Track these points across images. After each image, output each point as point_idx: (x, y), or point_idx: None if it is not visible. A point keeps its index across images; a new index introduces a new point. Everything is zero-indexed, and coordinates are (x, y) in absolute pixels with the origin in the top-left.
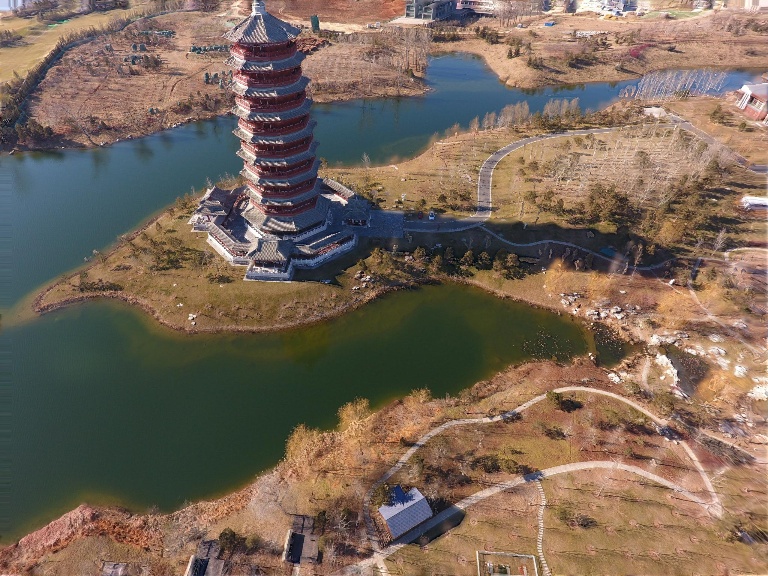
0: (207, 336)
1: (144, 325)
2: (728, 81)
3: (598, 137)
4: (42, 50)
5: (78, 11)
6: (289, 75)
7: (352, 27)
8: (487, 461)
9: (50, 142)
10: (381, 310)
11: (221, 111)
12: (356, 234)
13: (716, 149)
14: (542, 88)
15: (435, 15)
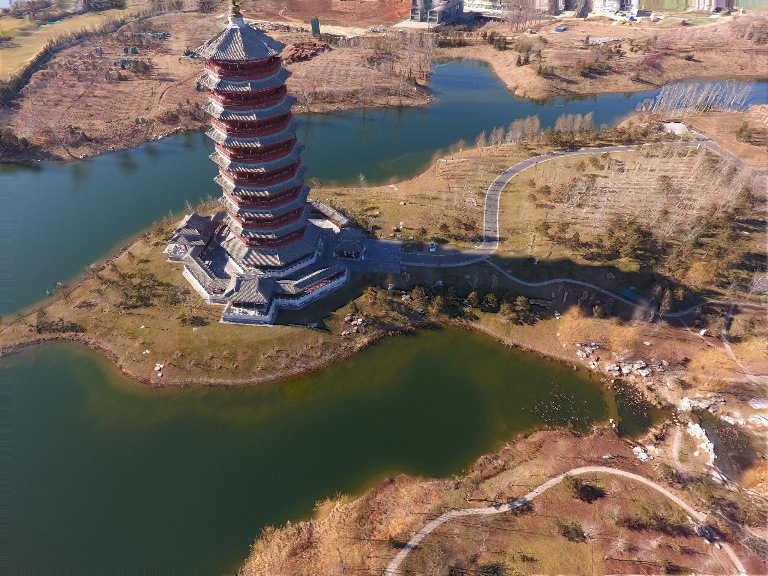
0: (174, 390)
1: (105, 375)
2: (753, 95)
3: (614, 156)
4: (30, 52)
5: (73, 11)
6: (271, 95)
7: (354, 31)
8: (492, 571)
9: (26, 154)
10: (373, 360)
11: None
12: (348, 268)
13: (747, 175)
14: (553, 98)
15: (441, 19)
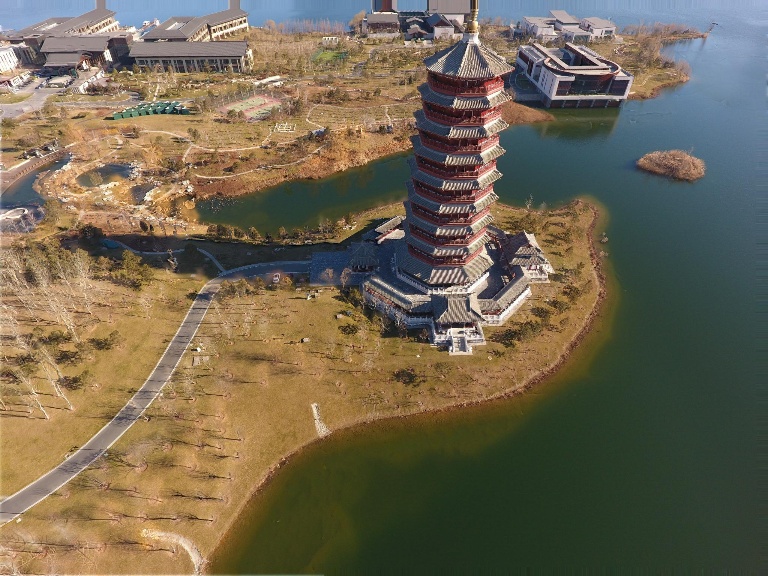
0: None
1: None
2: None
3: None
4: None
5: None
6: None
7: None
8: (282, 150)
9: None
10: (333, 219)
11: None
12: None
13: None
14: None
15: None
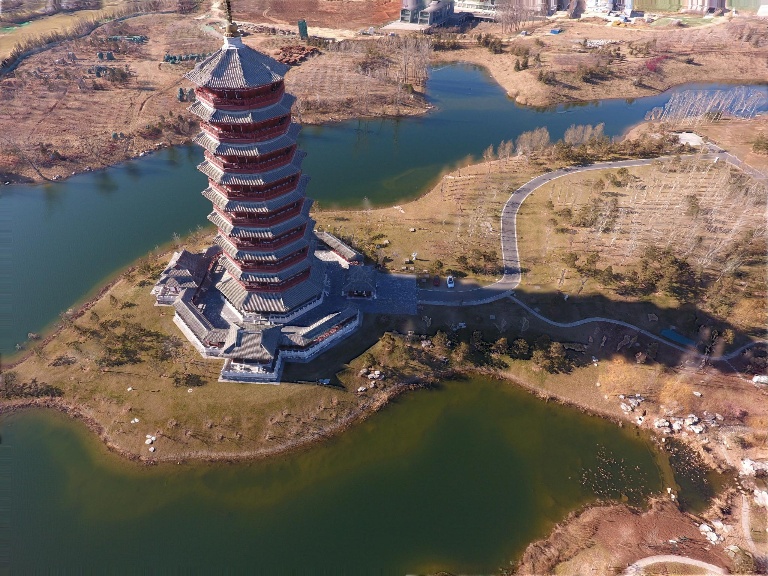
0: (169, 469)
1: (87, 451)
2: (763, 102)
3: (630, 171)
4: None
5: (42, 11)
6: (275, 125)
7: (343, 33)
8: None
9: None
10: (395, 420)
11: None
12: (360, 310)
13: None
14: (554, 105)
15: (432, 20)
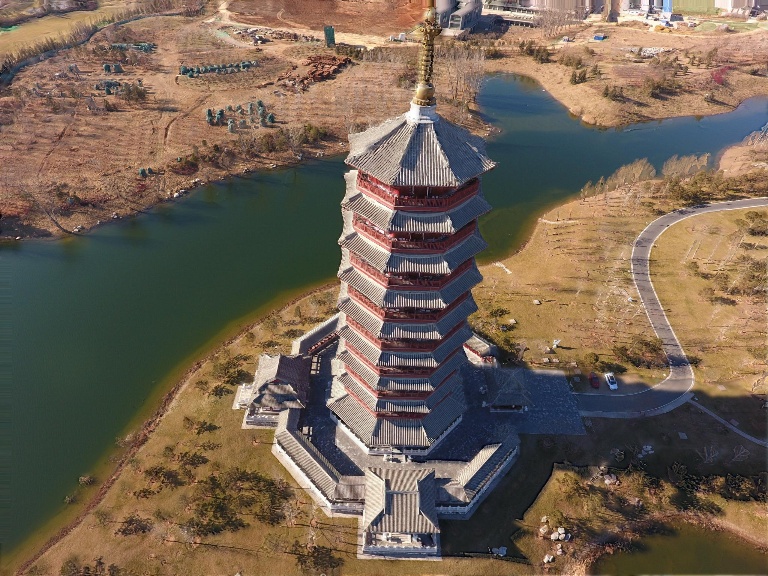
0: None
1: None
2: None
3: None
4: None
5: (29, 12)
6: None
7: (372, 39)
8: None
9: None
10: None
11: (236, 168)
12: None
13: None
14: None
15: (463, 24)
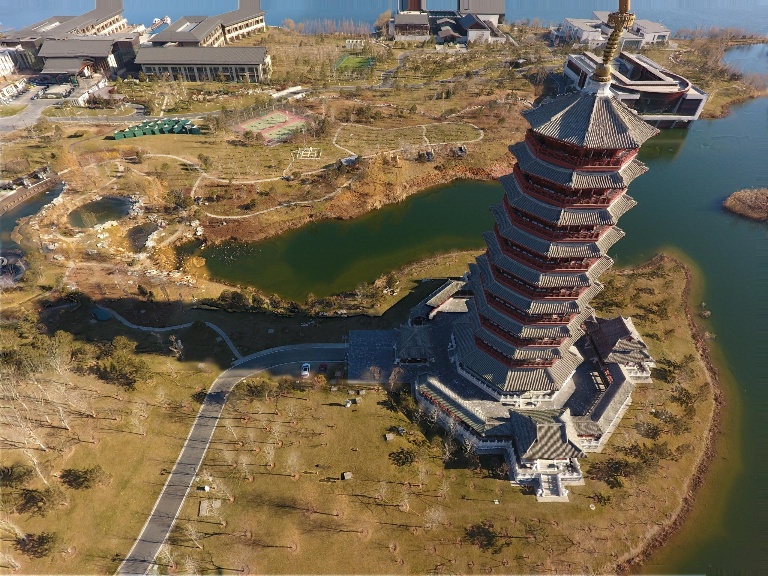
0: None
1: None
2: None
3: None
4: None
5: None
6: None
7: None
8: (306, 182)
9: None
10: (369, 276)
11: None
12: None
13: None
14: None
15: None
